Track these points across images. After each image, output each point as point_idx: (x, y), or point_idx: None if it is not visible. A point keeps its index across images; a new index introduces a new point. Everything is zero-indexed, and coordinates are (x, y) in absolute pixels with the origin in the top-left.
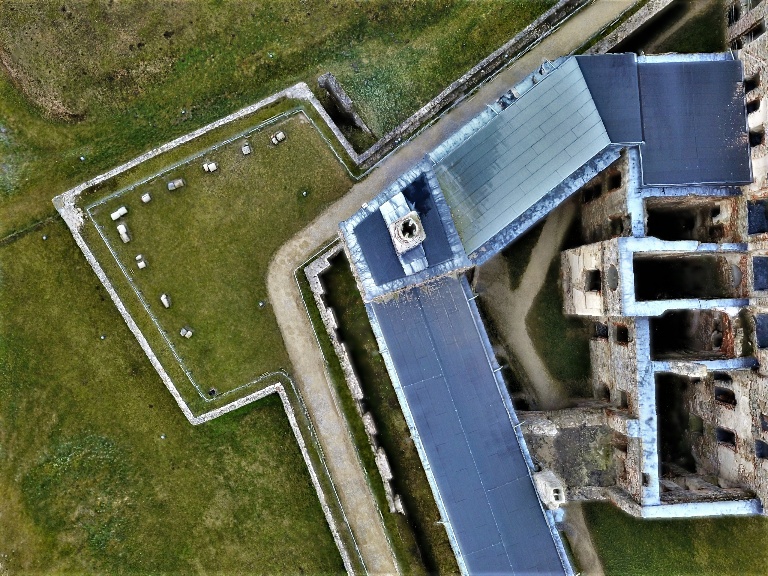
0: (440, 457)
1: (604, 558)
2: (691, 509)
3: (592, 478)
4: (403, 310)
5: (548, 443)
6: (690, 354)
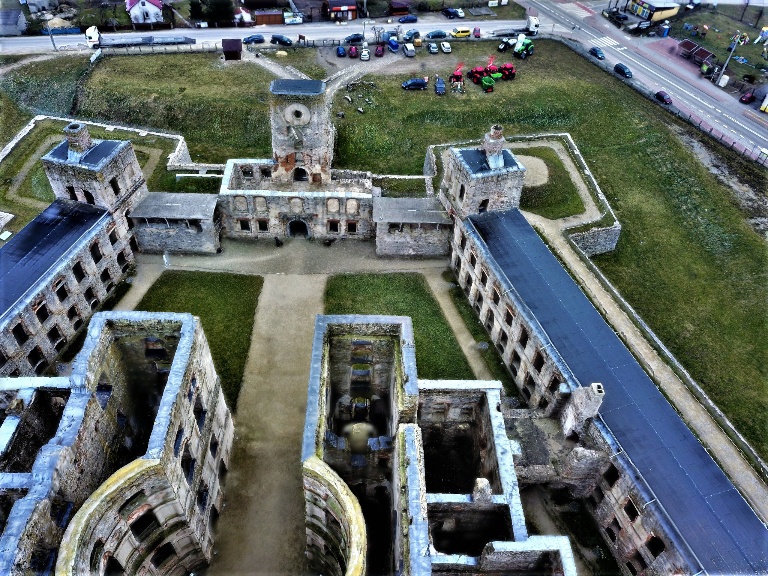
0: (680, 430)
1: (471, 377)
2: (462, 385)
3: (511, 424)
4: (766, 562)
5: (554, 453)
6: (449, 519)
